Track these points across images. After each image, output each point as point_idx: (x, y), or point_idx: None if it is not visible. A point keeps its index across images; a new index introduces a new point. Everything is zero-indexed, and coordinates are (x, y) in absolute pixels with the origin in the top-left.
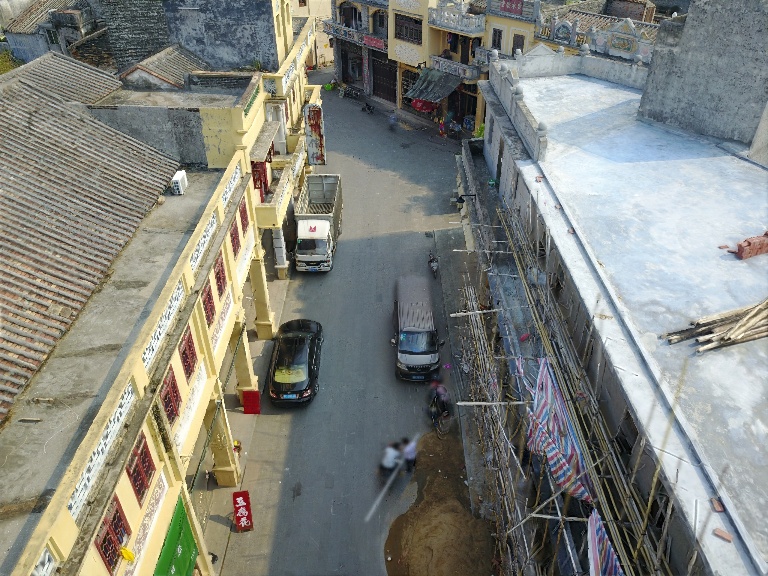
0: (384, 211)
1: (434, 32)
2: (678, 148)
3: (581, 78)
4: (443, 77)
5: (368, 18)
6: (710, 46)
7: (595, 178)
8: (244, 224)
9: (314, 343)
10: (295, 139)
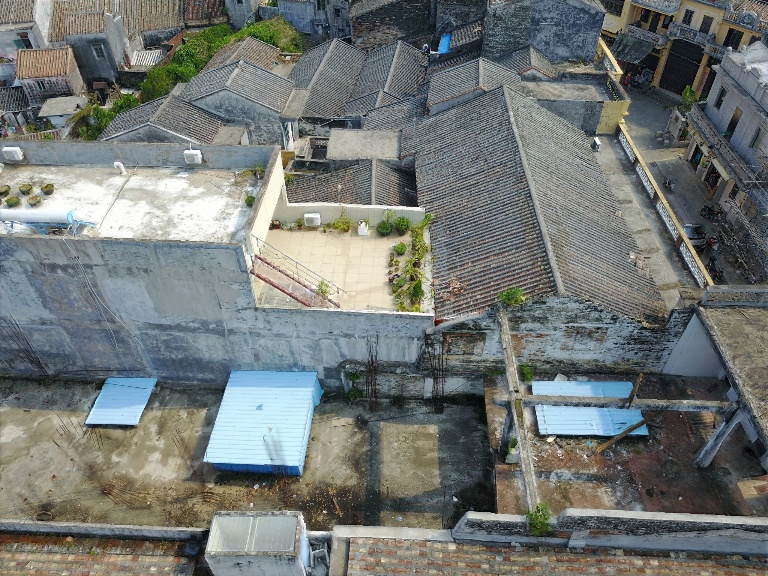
0: None
1: (633, 7)
2: None
3: None
4: (638, 42)
5: None
6: None
7: None
8: None
9: None
10: None
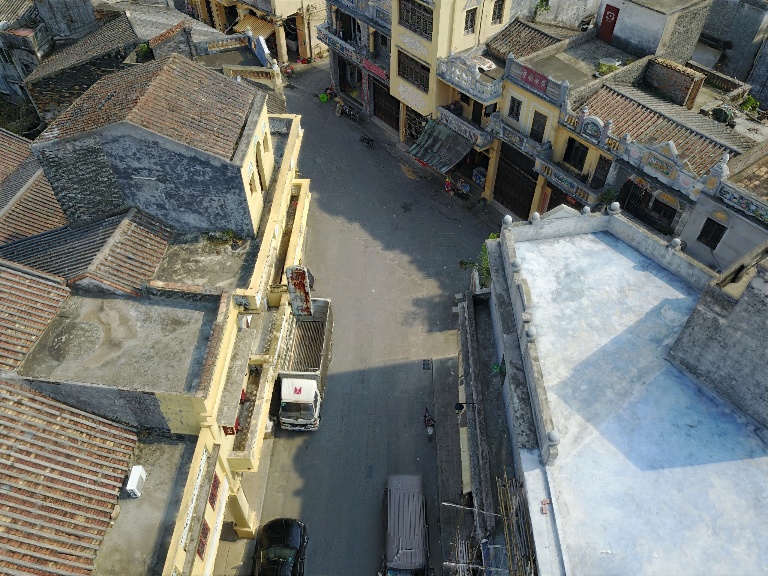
0: (379, 323)
1: (443, 83)
2: (710, 433)
3: (607, 242)
4: (451, 137)
5: (368, 35)
6: (764, 338)
7: (610, 510)
8: (214, 494)
9: (296, 565)
10: (277, 296)
